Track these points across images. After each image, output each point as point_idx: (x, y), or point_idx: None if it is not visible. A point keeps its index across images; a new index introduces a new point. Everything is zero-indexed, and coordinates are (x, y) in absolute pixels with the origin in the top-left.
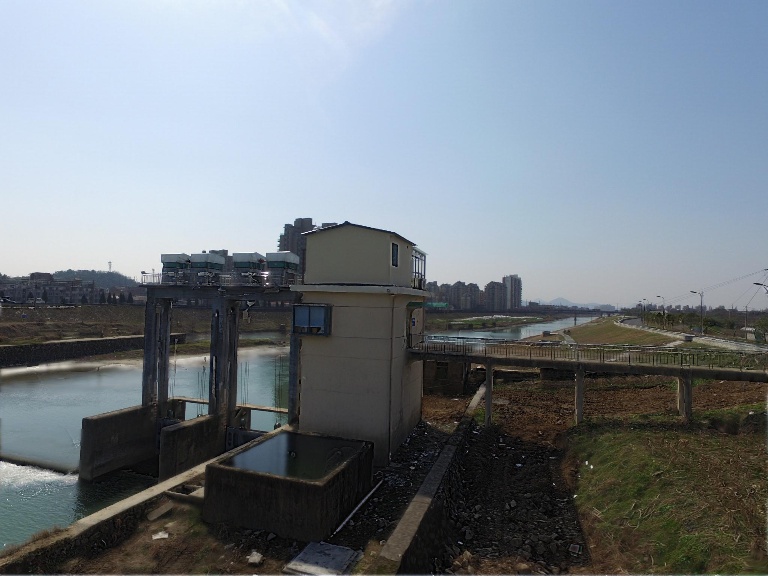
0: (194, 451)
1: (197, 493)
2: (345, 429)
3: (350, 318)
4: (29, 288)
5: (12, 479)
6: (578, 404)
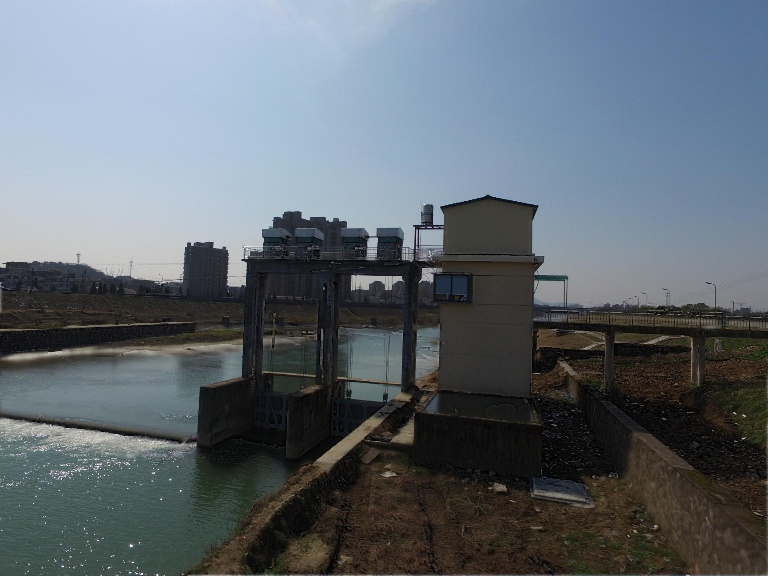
0: (313, 418)
1: (397, 440)
2: (487, 390)
3: (492, 286)
4: (25, 275)
5: (129, 447)
6: (700, 366)
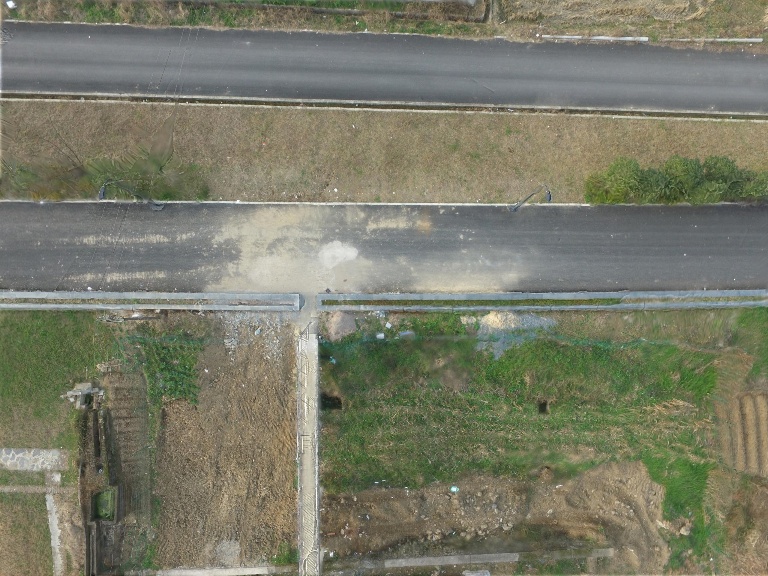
0: None
1: None
2: None
3: None
4: None
5: None
6: None
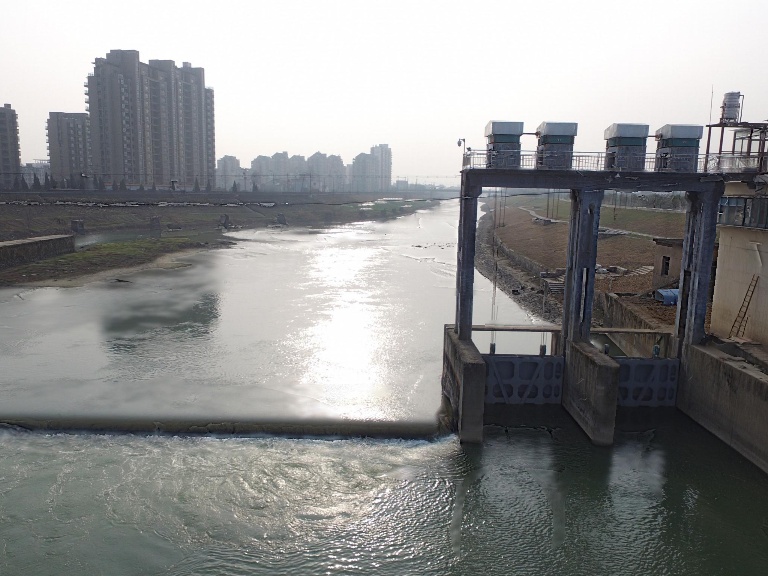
0: None
1: None
2: None
3: None
4: None
5: (373, 458)
6: None
